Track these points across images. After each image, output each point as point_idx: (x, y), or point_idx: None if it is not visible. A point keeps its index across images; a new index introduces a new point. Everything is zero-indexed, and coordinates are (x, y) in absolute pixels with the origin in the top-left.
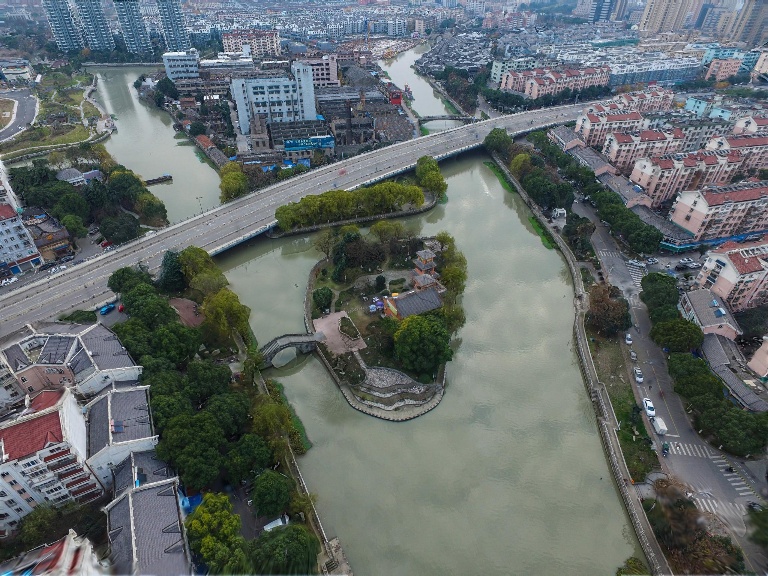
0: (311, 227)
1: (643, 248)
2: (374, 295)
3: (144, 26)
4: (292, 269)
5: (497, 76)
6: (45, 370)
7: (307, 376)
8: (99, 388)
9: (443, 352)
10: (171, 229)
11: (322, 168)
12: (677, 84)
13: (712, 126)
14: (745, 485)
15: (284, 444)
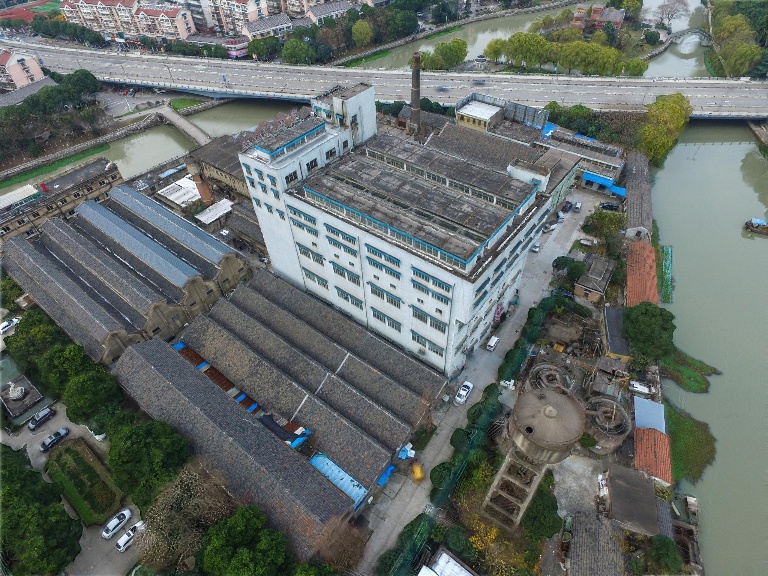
0: None
1: None
2: None
3: None
4: None
5: None
6: None
7: None
8: None
9: None
10: (762, 113)
11: None
12: None
13: None
14: None
15: None
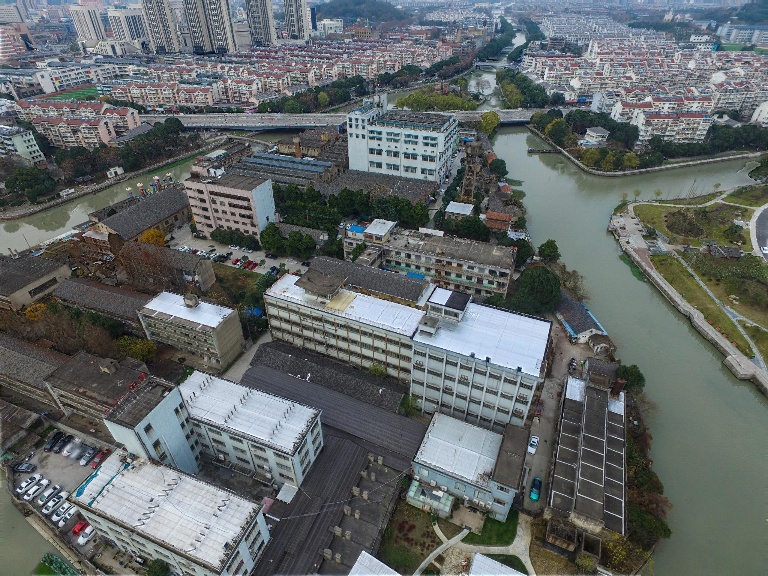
0: None
1: None
2: None
3: None
4: None
5: None
6: None
7: None
8: None
9: None
10: None
11: None
12: None
13: None
14: None
15: None
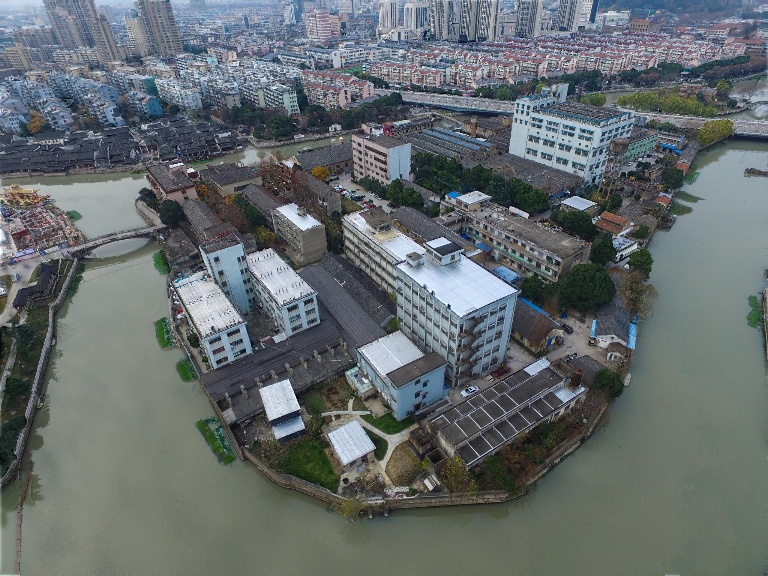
0: None
1: None
2: None
3: None
4: None
5: None
6: None
7: None
8: None
9: None
10: None
11: None
12: None
13: None
14: None
15: None
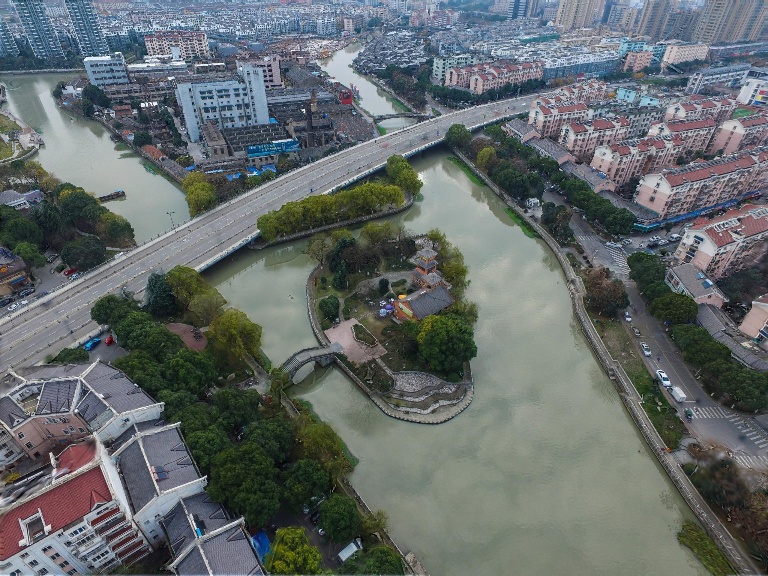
0: (294, 235)
1: (620, 230)
2: (379, 299)
3: (52, 29)
4: (281, 280)
5: (439, 73)
6: (45, 421)
7: (331, 390)
8: (118, 433)
9: (470, 349)
10: (142, 249)
11: (291, 173)
12: (601, 76)
13: (648, 113)
14: (761, 438)
15: (340, 464)
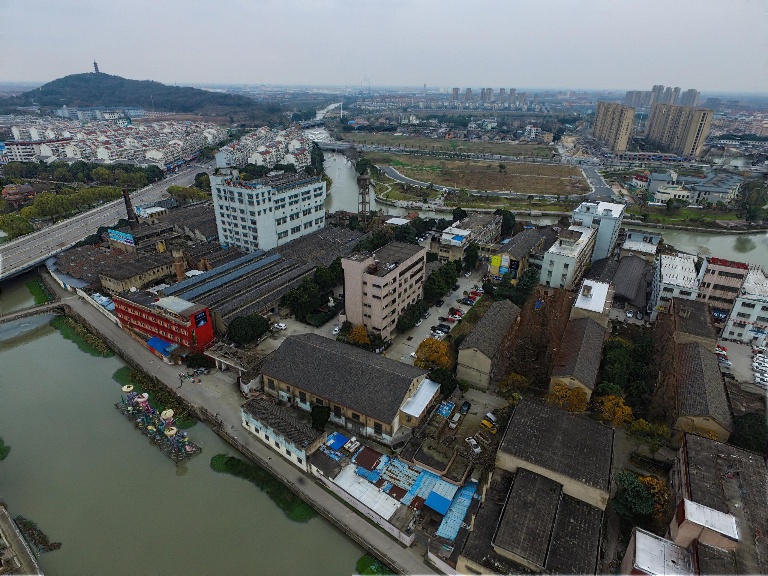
0: None
1: None
2: None
3: None
4: None
5: None
6: None
7: None
8: None
9: None
10: None
11: None
12: None
13: None
14: None
15: None
